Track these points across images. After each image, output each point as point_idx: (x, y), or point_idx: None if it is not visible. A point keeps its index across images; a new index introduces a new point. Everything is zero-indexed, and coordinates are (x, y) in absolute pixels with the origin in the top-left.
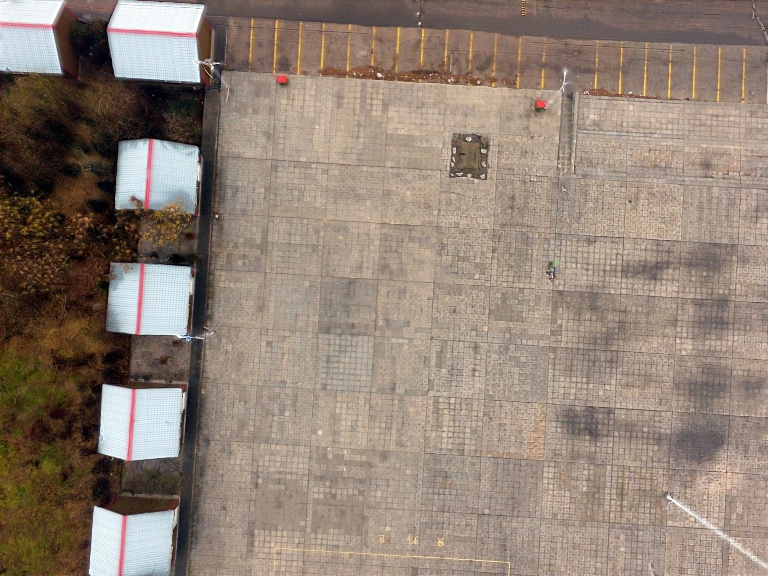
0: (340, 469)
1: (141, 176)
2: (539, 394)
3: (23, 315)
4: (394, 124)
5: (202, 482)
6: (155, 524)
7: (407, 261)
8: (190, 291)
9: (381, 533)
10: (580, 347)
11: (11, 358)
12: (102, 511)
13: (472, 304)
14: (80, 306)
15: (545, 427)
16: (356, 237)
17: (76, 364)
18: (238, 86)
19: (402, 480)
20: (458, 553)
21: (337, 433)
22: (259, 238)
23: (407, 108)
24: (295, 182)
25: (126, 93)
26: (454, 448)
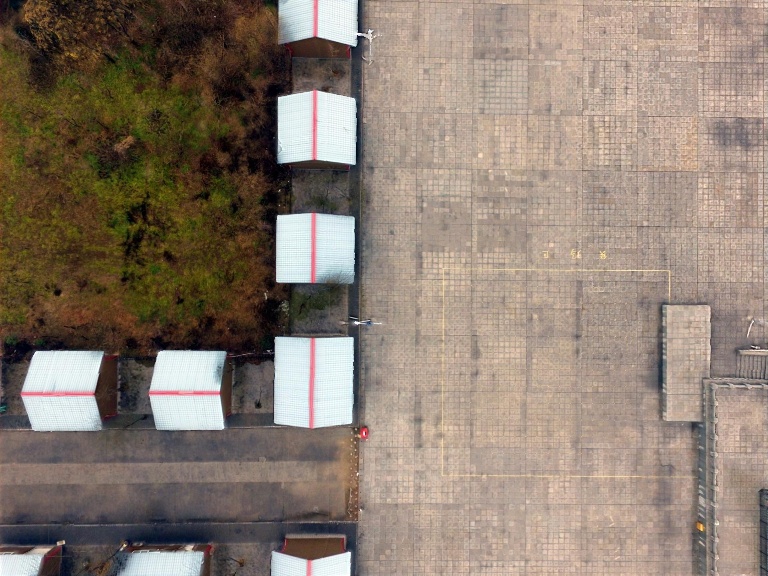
0: (502, 190)
1: None
2: (690, 108)
3: (183, 53)
4: None
5: (369, 209)
6: (340, 227)
7: None
8: (357, 4)
9: (545, 249)
10: (727, 61)
11: (174, 95)
12: (287, 217)
13: (621, 24)
14: (239, 42)
15: (697, 140)
16: None
17: (239, 99)
18: None
19: (562, 197)
20: (620, 265)
21: (497, 155)
22: None
23: None
24: None
25: None
26: (611, 164)
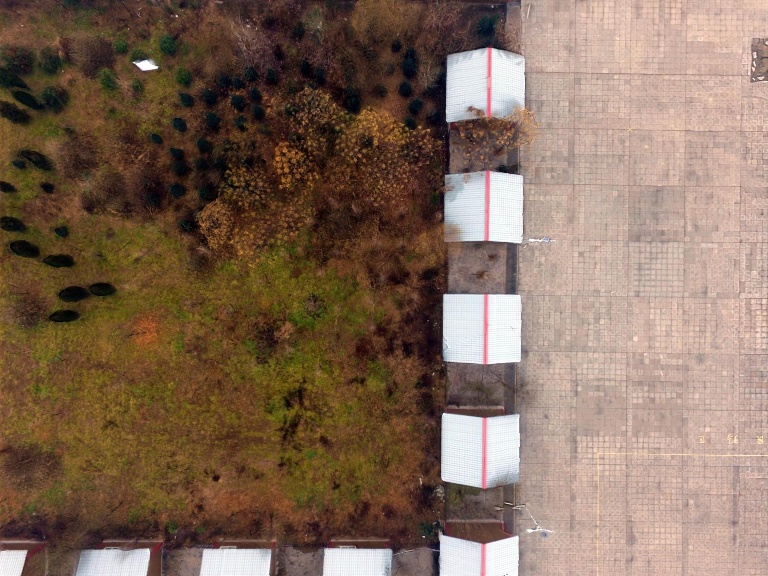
0: (657, 374)
1: (481, 86)
2: None
3: (339, 237)
4: (694, 32)
5: (523, 392)
6: (507, 427)
7: (713, 167)
8: (522, 200)
9: (701, 434)
10: None
11: (330, 280)
12: (454, 417)
13: None
14: (394, 226)
15: None
16: (661, 145)
17: (394, 283)
18: (538, 2)
19: (719, 381)
20: None
21: (652, 339)
22: (566, 151)
23: (706, 15)
24: (599, 94)
25: (457, 6)
26: None
